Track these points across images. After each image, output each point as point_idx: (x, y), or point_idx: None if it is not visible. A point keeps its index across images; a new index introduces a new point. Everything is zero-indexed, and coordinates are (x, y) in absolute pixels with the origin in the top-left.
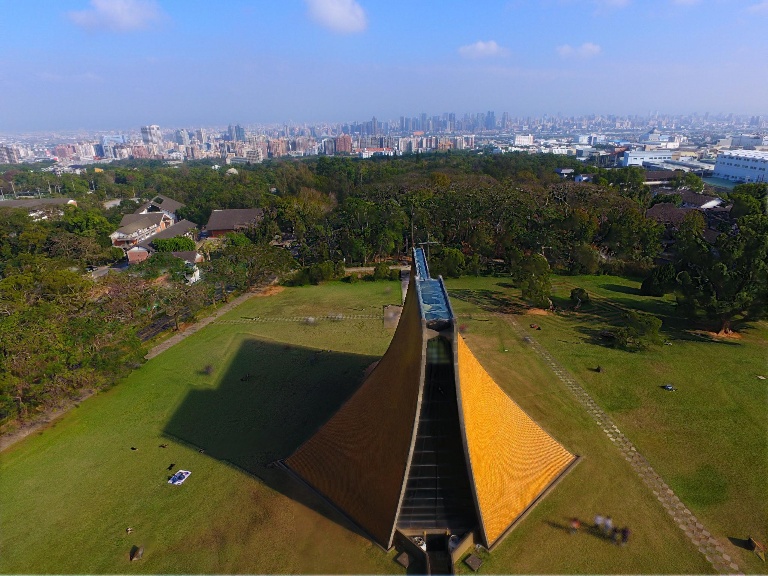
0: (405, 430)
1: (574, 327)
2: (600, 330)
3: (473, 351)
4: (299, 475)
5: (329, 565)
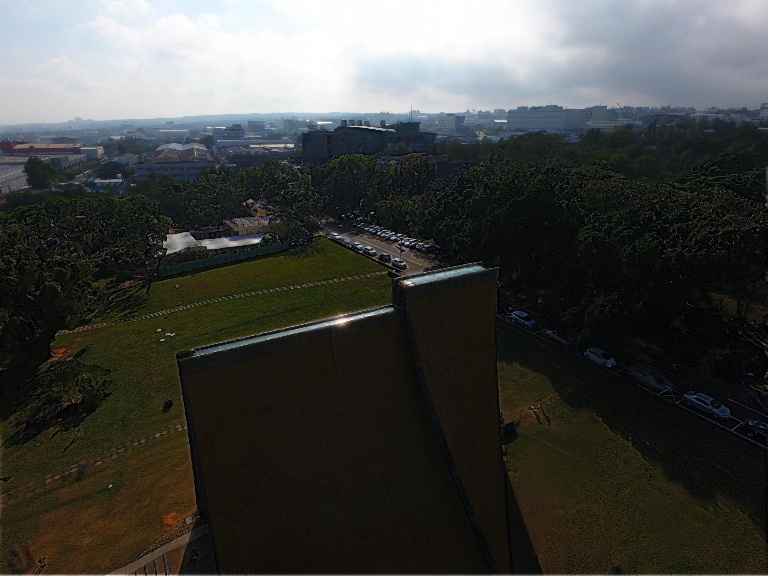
0: (491, 365)
1: (8, 446)
2: (29, 423)
3: (117, 520)
4: (511, 567)
5: (549, 486)
